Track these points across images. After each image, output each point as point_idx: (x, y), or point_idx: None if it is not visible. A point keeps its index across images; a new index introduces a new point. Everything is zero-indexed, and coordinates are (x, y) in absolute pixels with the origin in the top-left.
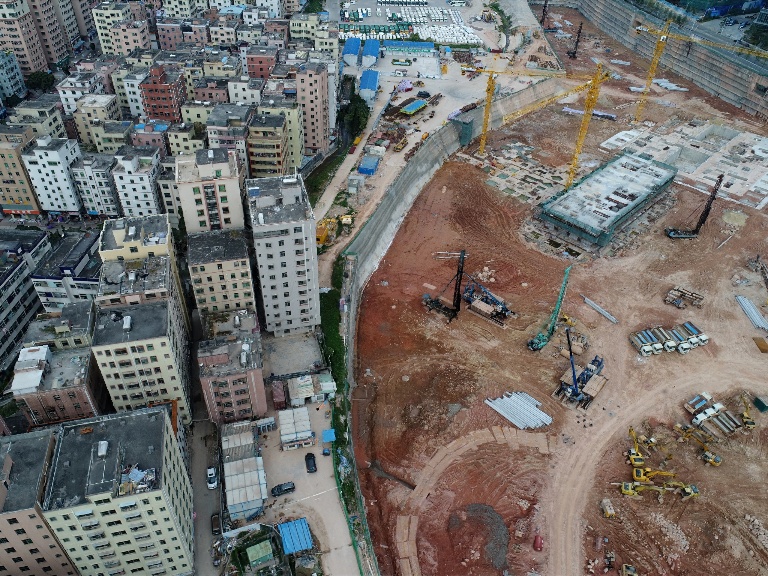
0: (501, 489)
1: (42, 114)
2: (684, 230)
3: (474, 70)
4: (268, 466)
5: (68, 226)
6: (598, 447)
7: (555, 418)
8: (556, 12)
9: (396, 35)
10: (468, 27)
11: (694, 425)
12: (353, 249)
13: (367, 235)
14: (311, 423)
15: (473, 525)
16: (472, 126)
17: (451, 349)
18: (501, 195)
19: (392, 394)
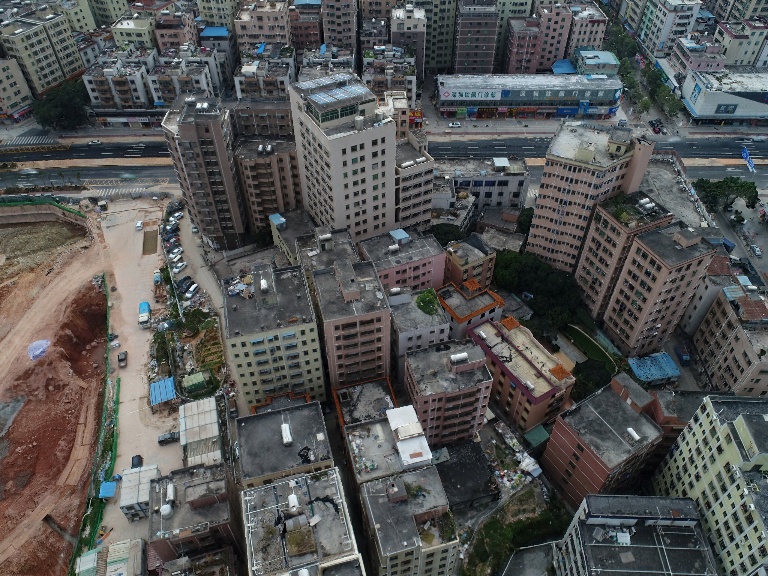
0: None
1: None
2: None
3: None
4: None
5: None
6: None
7: None
8: None
9: None
10: None
11: None
12: None
13: None
14: (126, 520)
15: (6, 474)
16: None
17: None
18: None
19: None
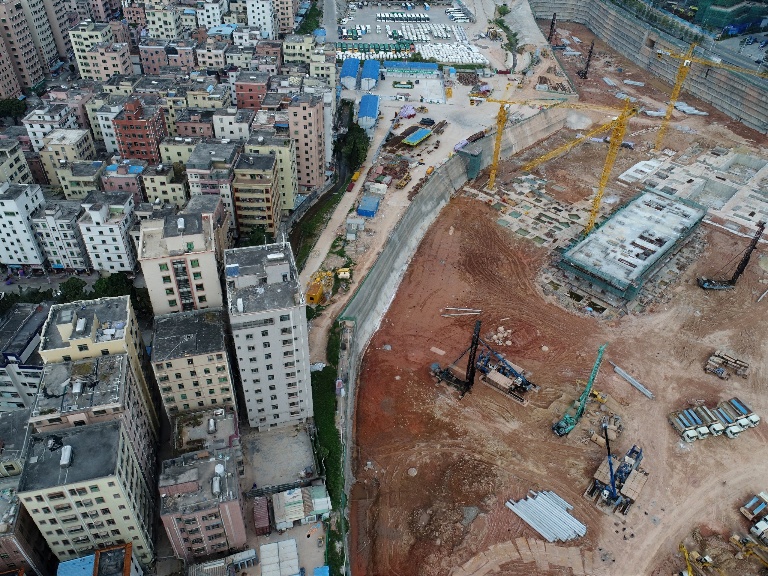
0: None
1: (2, 154)
2: (718, 280)
3: None
4: None
5: (30, 281)
6: (642, 566)
7: (589, 526)
8: (563, 28)
9: (397, 54)
10: (473, 45)
11: (753, 535)
12: (351, 310)
13: (367, 291)
14: (300, 554)
15: None
16: (480, 157)
17: (464, 433)
18: (514, 237)
19: (397, 493)
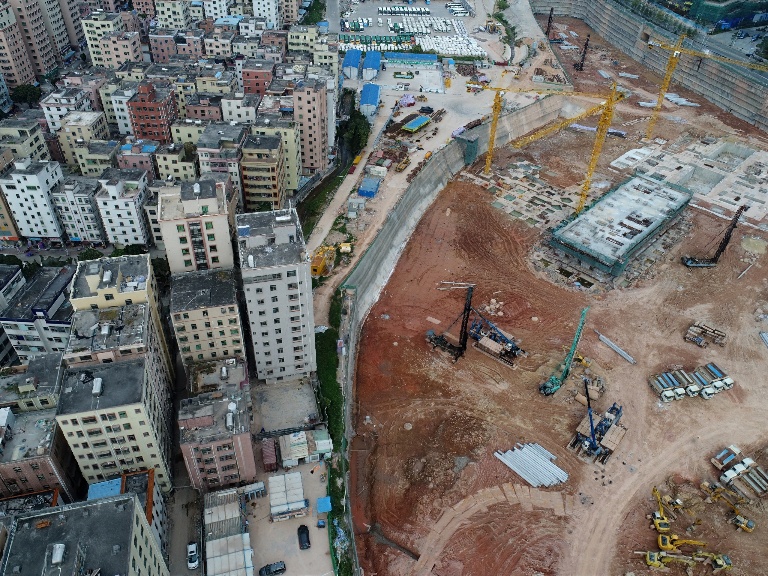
0: (514, 559)
1: (23, 133)
2: (702, 258)
3: (480, 87)
4: (256, 541)
5: (49, 253)
6: (619, 508)
7: (571, 474)
8: (561, 22)
9: (398, 46)
10: (472, 38)
11: (722, 483)
12: (352, 281)
13: (367, 264)
14: (305, 488)
15: None
16: (477, 144)
17: (457, 392)
18: (508, 218)
19: (394, 445)
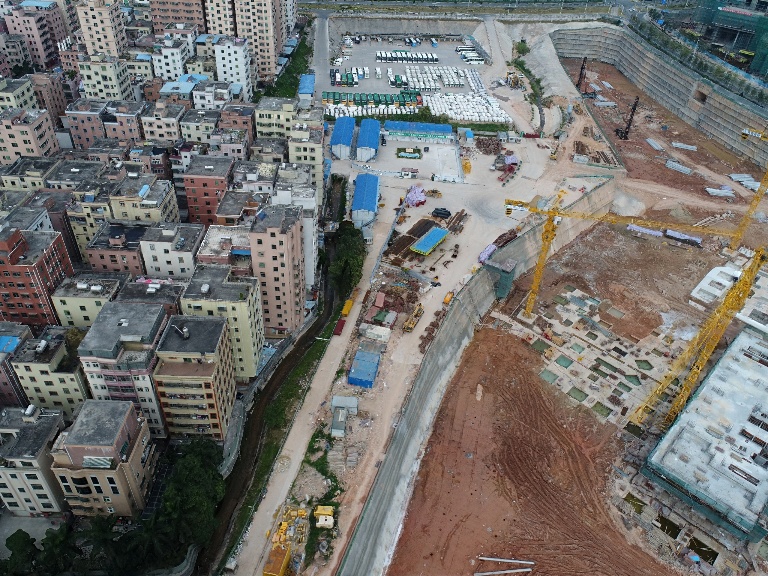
0: None
1: None
2: None
3: None
4: None
5: None
6: None
7: None
8: (590, 69)
9: (401, 109)
10: (491, 97)
11: None
12: None
13: (360, 547)
14: None
15: None
16: None
17: None
18: (567, 404)
19: None
